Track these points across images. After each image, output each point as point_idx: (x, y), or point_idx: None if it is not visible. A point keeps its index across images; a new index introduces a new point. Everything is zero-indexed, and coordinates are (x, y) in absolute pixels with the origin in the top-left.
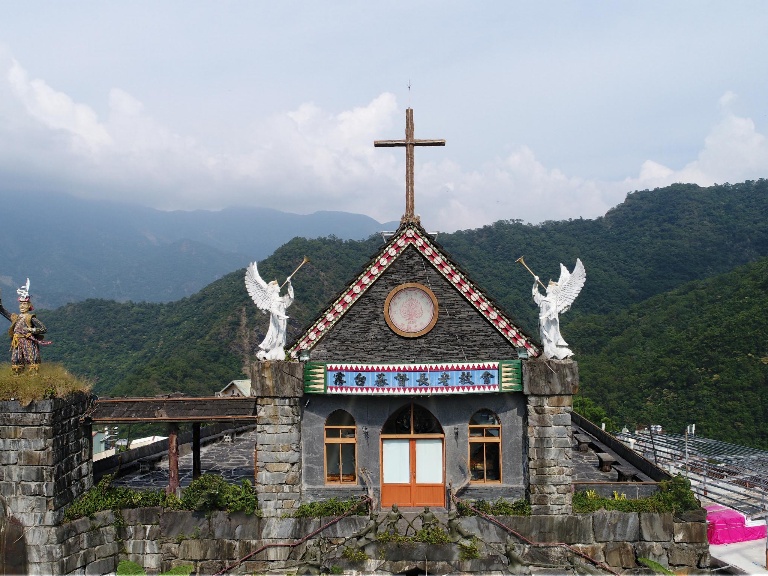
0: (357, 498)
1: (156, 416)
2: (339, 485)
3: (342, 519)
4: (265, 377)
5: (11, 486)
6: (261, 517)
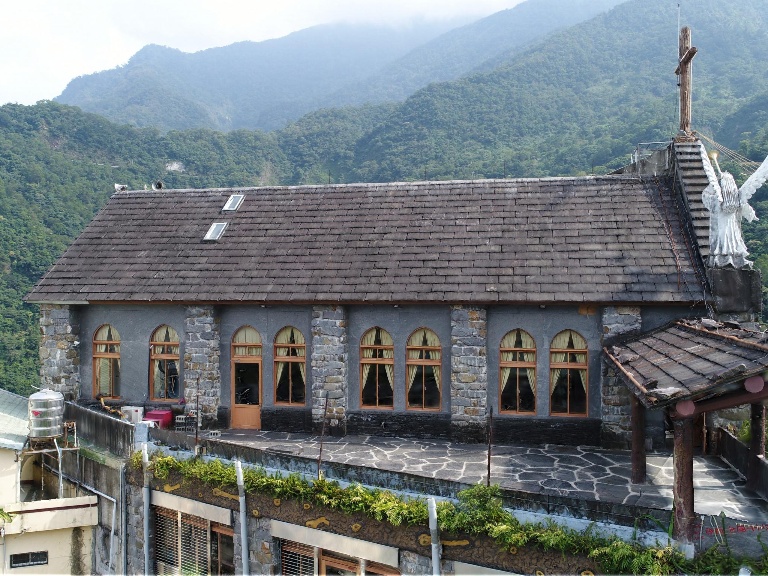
0: None
1: None
2: None
3: None
4: None
5: None
6: None
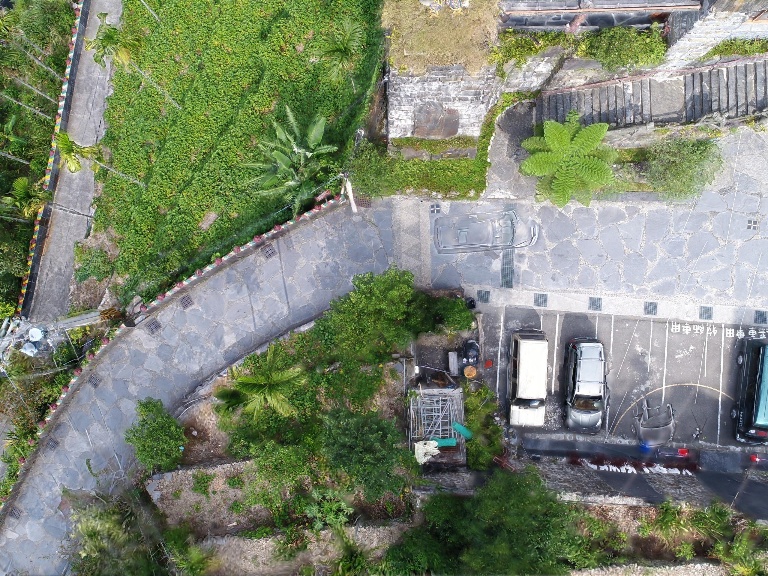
0: (764, 35)
1: (581, 7)
2: (751, 25)
3: (742, 58)
4: (735, 0)
5: (449, 99)
6: (664, 60)
